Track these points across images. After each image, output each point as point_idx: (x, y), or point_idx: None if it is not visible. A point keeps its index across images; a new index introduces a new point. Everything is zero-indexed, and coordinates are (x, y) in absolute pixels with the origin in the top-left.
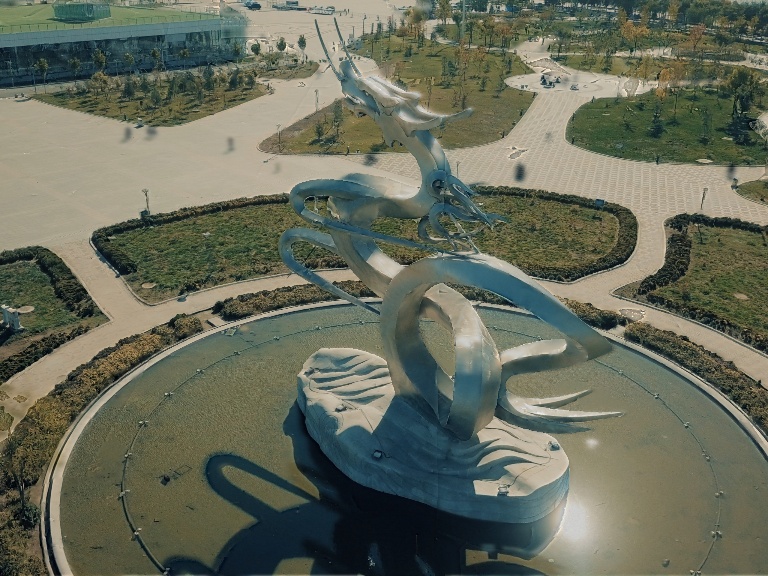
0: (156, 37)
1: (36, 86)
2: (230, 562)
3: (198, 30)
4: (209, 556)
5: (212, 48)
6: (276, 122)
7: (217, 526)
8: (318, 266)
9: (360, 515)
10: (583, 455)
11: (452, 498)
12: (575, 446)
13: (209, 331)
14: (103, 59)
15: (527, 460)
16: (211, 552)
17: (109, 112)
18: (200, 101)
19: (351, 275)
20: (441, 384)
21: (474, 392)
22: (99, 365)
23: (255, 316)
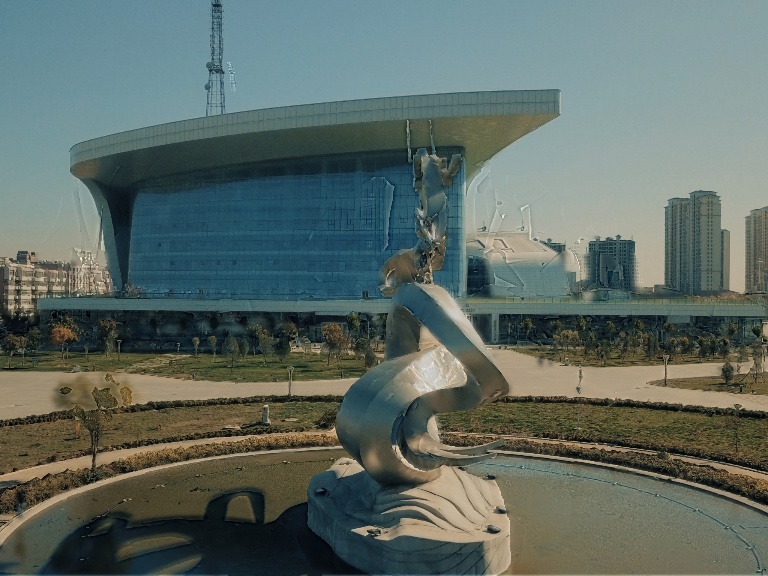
0: (657, 317)
1: (519, 341)
2: (144, 527)
3: (706, 314)
4: (139, 521)
5: (721, 333)
6: (702, 373)
7: (174, 513)
8: None
9: (300, 559)
10: (559, 574)
11: (340, 536)
12: (564, 568)
13: None
14: (584, 324)
15: (431, 520)
16: (144, 520)
17: (555, 358)
18: (649, 358)
19: None
20: None
21: (362, 406)
22: (267, 437)
23: None
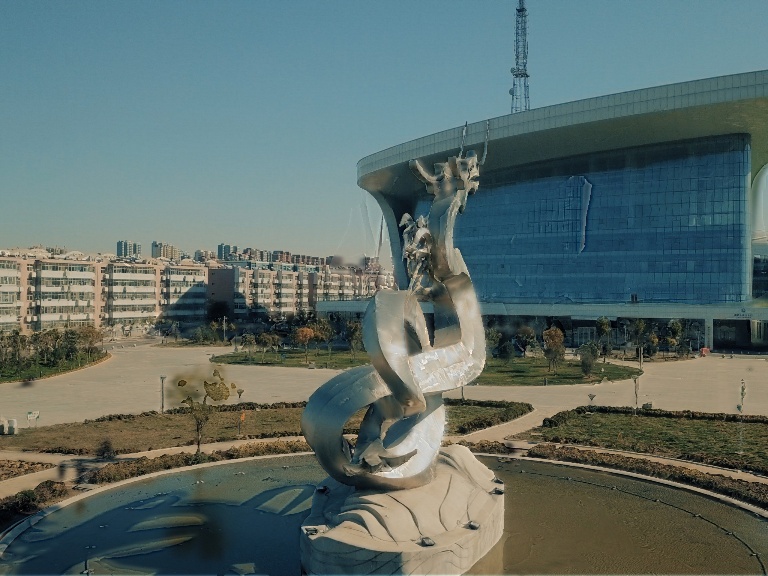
0: None
1: None
2: None
3: None
4: (188, 501)
5: None
6: None
7: None
8: (702, 462)
9: None
10: None
11: None
12: None
13: (491, 454)
14: None
15: (367, 525)
16: None
17: None
18: None
19: (709, 471)
20: (394, 443)
21: (319, 408)
22: None
23: (544, 459)
